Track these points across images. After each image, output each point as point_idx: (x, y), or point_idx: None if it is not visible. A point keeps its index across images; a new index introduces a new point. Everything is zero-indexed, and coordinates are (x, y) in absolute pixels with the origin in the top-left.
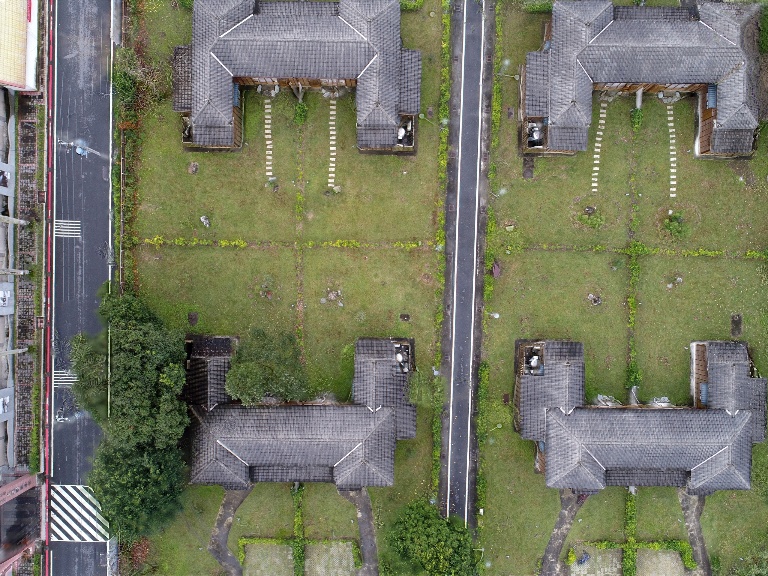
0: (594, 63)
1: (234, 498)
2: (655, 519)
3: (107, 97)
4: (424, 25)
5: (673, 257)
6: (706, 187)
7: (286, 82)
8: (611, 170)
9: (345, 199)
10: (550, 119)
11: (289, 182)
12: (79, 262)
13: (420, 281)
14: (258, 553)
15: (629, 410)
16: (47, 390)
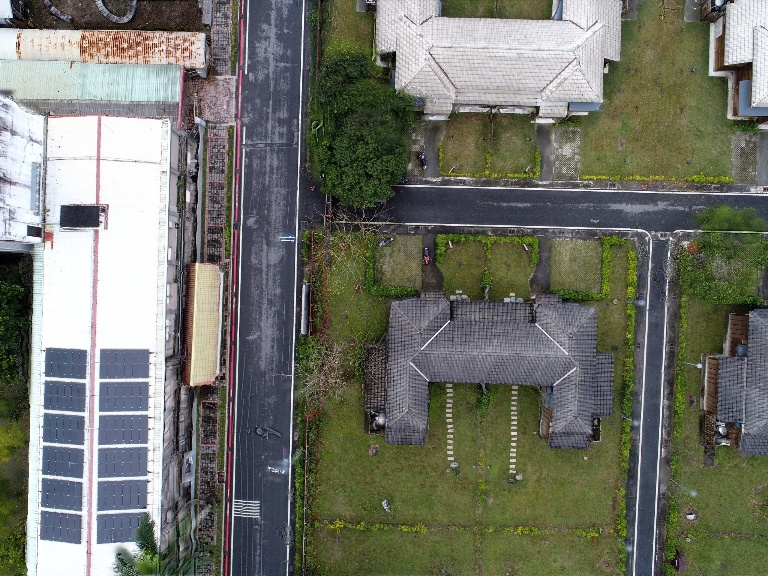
0: None
1: None
2: None
3: (289, 378)
4: (607, 312)
5: None
6: None
7: None
8: None
9: (525, 484)
10: (745, 429)
11: (470, 467)
12: (257, 542)
13: (599, 567)
14: None
15: None
16: None
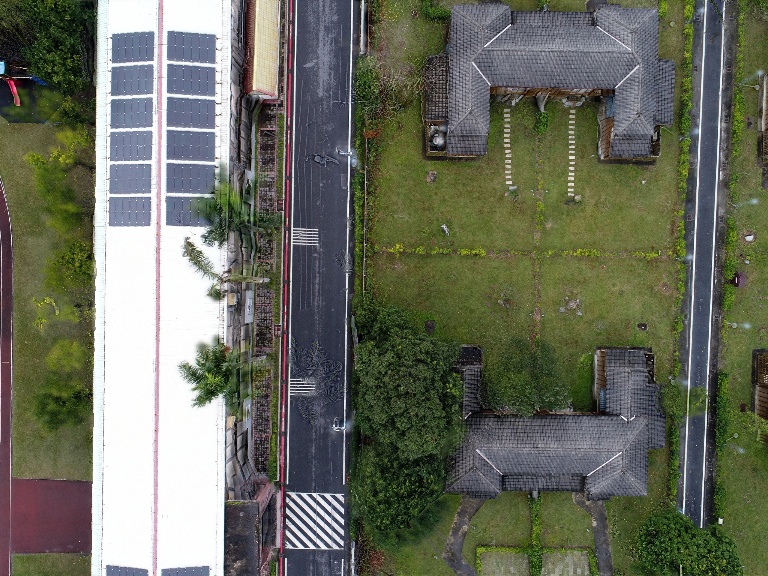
0: None
1: (470, 506)
2: None
3: (346, 106)
4: (664, 35)
5: None
6: None
7: (536, 92)
8: None
9: (584, 208)
10: None
11: (528, 191)
12: (317, 270)
13: (658, 290)
14: (493, 561)
15: None
16: (283, 398)
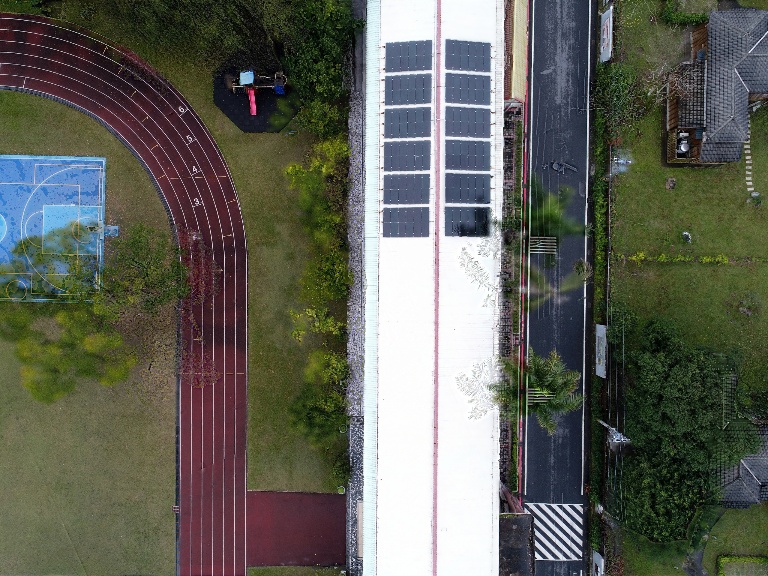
0: None
1: (710, 516)
2: None
3: (584, 112)
4: None
5: None
6: None
7: None
8: None
9: None
10: None
11: None
12: (555, 279)
13: None
14: (733, 571)
15: None
16: (521, 408)
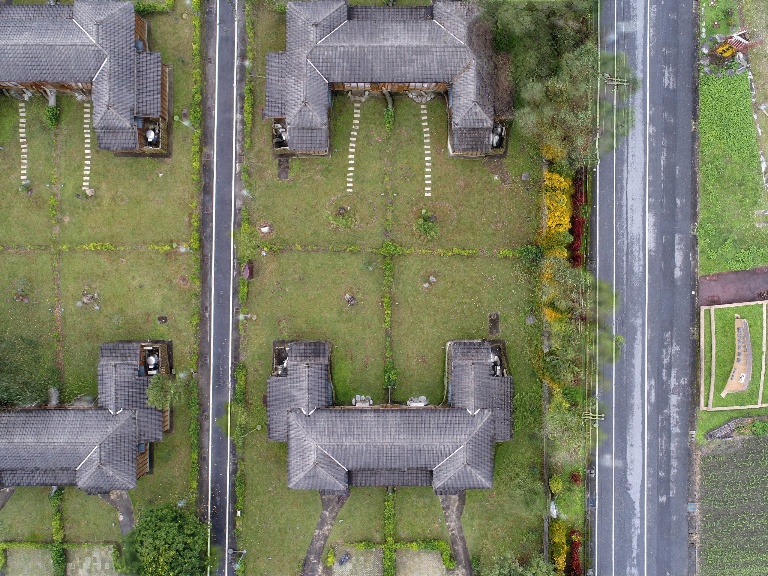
0: (325, 63)
1: None
2: (416, 519)
3: None
4: (177, 27)
5: (429, 256)
6: (461, 186)
7: (29, 86)
8: (366, 170)
9: (100, 202)
10: (286, 120)
11: (44, 186)
12: None
13: (177, 283)
14: (20, 557)
15: (370, 410)
16: None
